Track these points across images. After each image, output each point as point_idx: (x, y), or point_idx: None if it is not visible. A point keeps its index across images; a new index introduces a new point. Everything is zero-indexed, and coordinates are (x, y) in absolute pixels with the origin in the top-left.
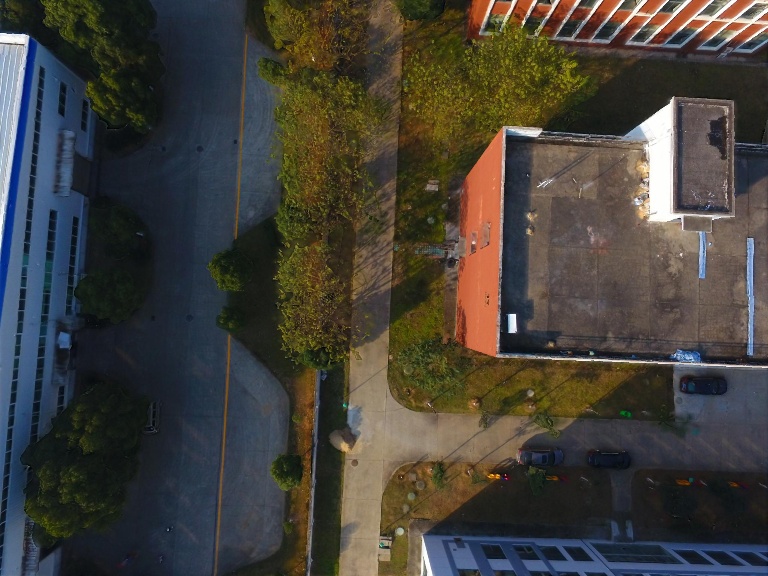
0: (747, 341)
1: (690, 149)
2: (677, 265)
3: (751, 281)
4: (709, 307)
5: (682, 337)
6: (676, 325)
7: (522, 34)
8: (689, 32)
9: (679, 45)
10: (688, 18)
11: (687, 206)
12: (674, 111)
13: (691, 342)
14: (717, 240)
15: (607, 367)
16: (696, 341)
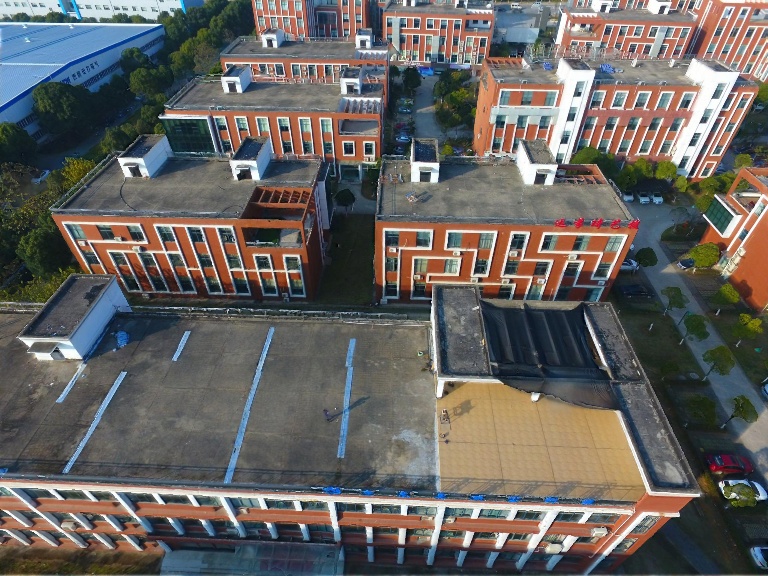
0: (70, 459)
1: (66, 301)
2: (42, 392)
3: (106, 405)
4: (50, 427)
5: (3, 455)
6: (5, 443)
7: (70, 271)
8: (245, 283)
9: (248, 293)
10: (227, 270)
11: (36, 334)
12: (66, 280)
13: (9, 459)
14: (92, 373)
15: (80, 572)
16: (15, 458)
